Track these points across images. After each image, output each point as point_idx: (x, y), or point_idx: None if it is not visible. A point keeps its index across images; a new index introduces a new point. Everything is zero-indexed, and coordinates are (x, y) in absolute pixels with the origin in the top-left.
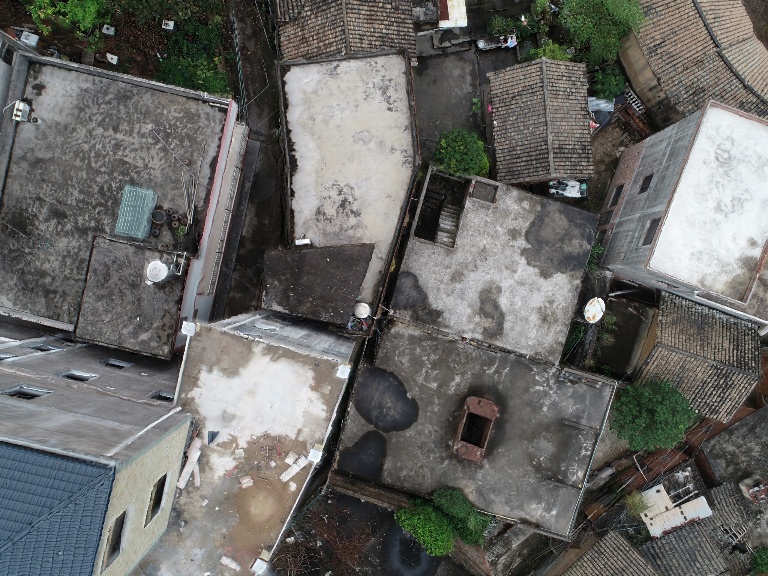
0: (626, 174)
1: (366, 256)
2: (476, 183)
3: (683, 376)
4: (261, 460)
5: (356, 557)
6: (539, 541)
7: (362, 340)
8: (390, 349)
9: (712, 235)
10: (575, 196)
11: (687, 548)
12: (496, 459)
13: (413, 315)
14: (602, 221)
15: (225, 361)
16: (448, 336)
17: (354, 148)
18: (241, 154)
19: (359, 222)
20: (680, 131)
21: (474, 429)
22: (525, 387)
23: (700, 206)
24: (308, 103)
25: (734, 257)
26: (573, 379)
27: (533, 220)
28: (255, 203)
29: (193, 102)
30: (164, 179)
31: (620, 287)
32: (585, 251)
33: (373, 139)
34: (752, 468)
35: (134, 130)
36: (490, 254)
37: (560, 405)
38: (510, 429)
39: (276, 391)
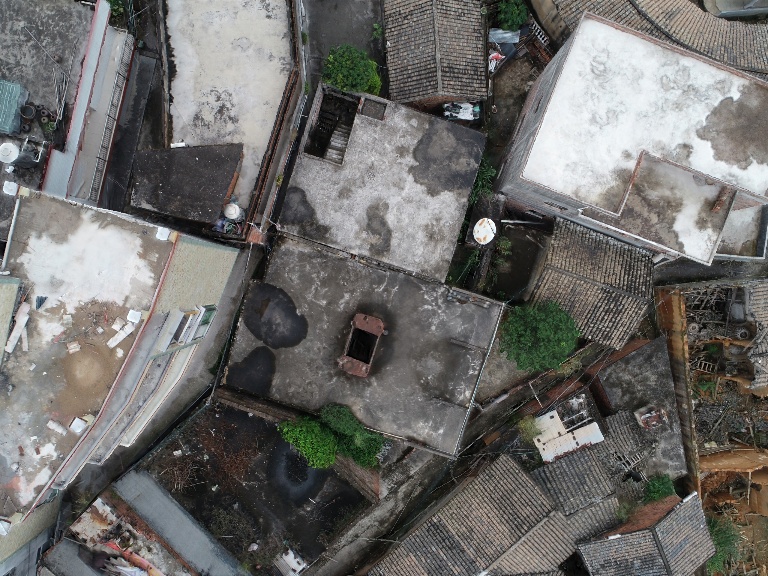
0: (528, 104)
1: (234, 156)
2: (366, 101)
3: (574, 300)
4: (89, 326)
5: (243, 471)
6: (440, 471)
7: (258, 261)
8: (280, 266)
9: (587, 147)
10: (468, 118)
11: (577, 472)
12: (384, 377)
13: (301, 230)
14: (507, 153)
15: (54, 227)
16: (338, 254)
17: (233, 55)
18: (125, 62)
19: (237, 128)
20: (564, 49)
21: (362, 346)
22: (414, 306)
23: (575, 118)
24: (187, 9)
25: (608, 169)
26: (461, 298)
27: (421, 138)
28: (150, 120)
29: (65, 0)
30: (36, 76)
31: (523, 218)
32: (472, 169)
33: (252, 46)
34: (648, 397)
35: (6, 27)
36: (378, 171)
37: (448, 324)
38: (398, 347)
39: (104, 258)
